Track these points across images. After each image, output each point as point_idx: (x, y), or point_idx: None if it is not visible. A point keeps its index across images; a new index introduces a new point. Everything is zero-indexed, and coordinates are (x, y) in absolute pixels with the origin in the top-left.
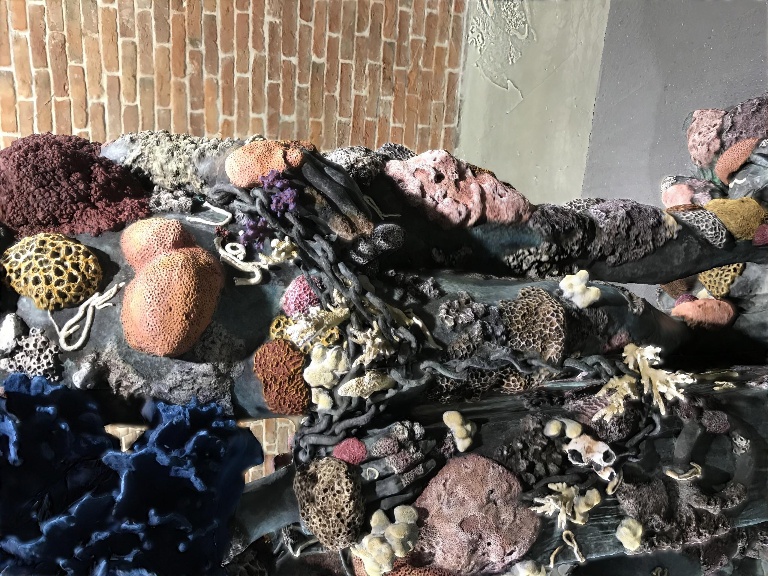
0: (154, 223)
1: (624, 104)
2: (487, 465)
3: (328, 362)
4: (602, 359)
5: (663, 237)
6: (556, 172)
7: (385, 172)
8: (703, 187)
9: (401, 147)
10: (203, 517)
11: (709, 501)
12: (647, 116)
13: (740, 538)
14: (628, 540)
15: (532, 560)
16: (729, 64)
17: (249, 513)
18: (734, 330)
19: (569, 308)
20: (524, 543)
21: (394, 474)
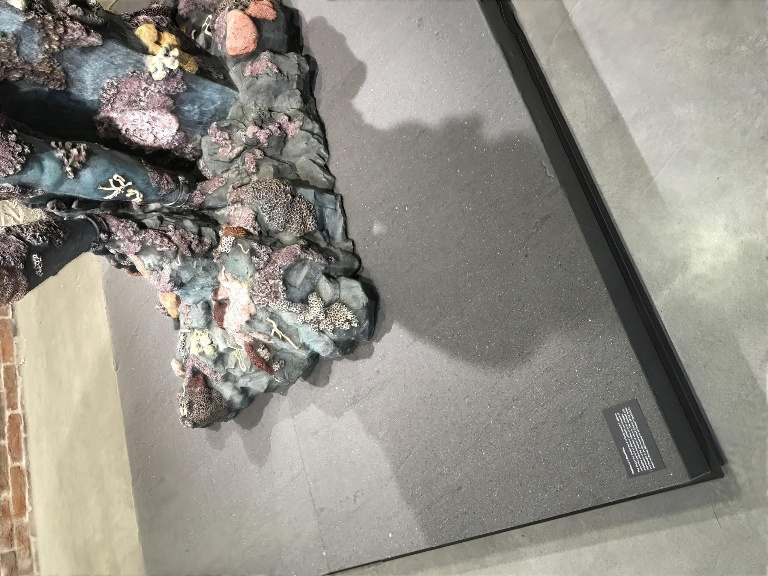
0: None
1: None
2: None
3: None
4: None
5: None
6: (89, 265)
7: None
8: None
9: None
10: None
11: (73, 4)
12: None
13: (179, 175)
14: None
15: None
16: None
17: None
18: None
19: None
20: None
21: None
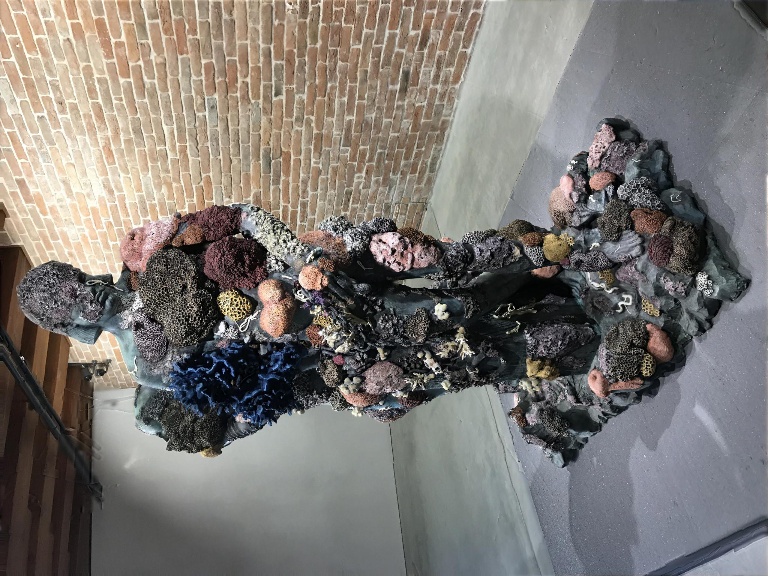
0: (271, 291)
1: (592, 56)
2: (391, 366)
3: (333, 338)
4: (443, 339)
5: (509, 261)
6: (559, 37)
7: (369, 248)
8: (579, 189)
9: (382, 220)
10: (288, 387)
11: (481, 379)
12: (599, 79)
13: None
14: (444, 387)
15: (404, 391)
16: (641, 92)
17: (302, 366)
18: (556, 278)
19: (434, 320)
20: (401, 388)
21: (354, 369)
